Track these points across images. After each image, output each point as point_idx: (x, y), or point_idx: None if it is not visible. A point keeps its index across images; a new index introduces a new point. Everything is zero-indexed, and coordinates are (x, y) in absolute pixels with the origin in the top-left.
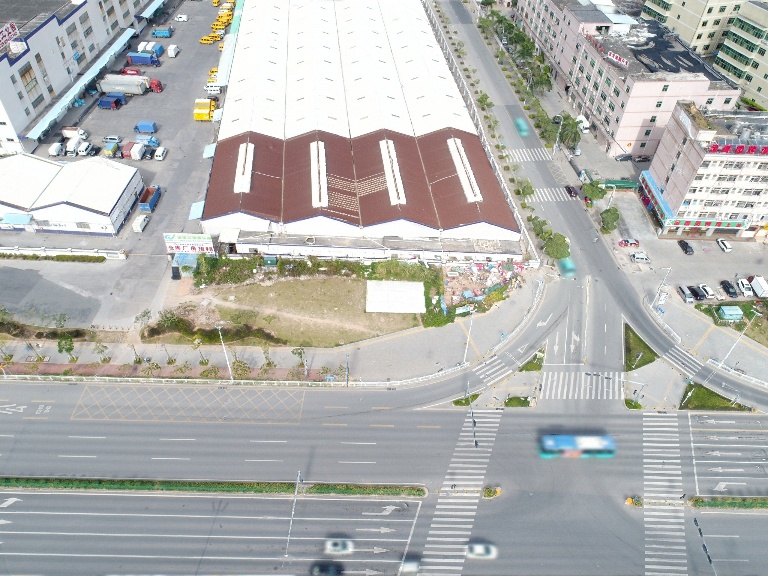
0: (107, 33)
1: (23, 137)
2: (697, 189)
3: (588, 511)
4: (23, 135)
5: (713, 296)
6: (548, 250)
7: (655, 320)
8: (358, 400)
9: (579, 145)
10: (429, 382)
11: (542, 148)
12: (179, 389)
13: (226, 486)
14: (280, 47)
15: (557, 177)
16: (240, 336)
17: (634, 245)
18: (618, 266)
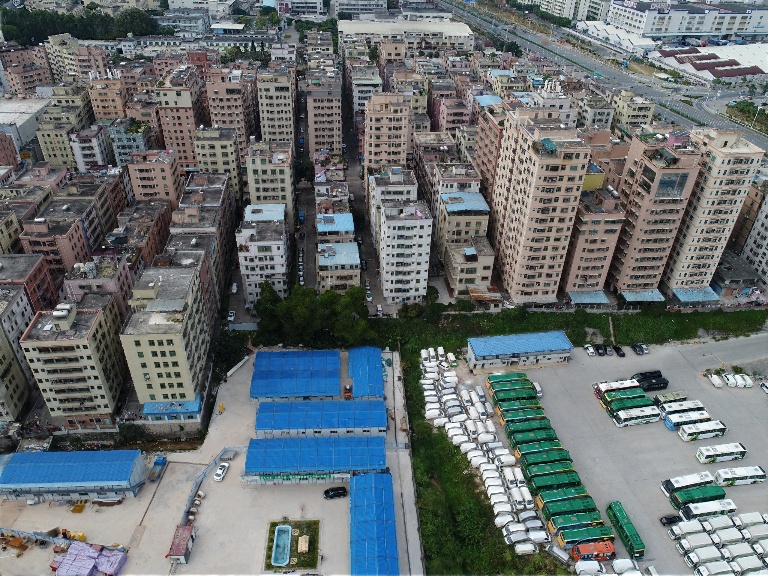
0: (711, 29)
1: (643, 34)
2: None
3: None
4: (644, 33)
5: None
6: None
7: None
8: None
9: None
10: None
11: None
12: None
13: None
14: (763, 48)
15: None
16: None
17: None
18: None
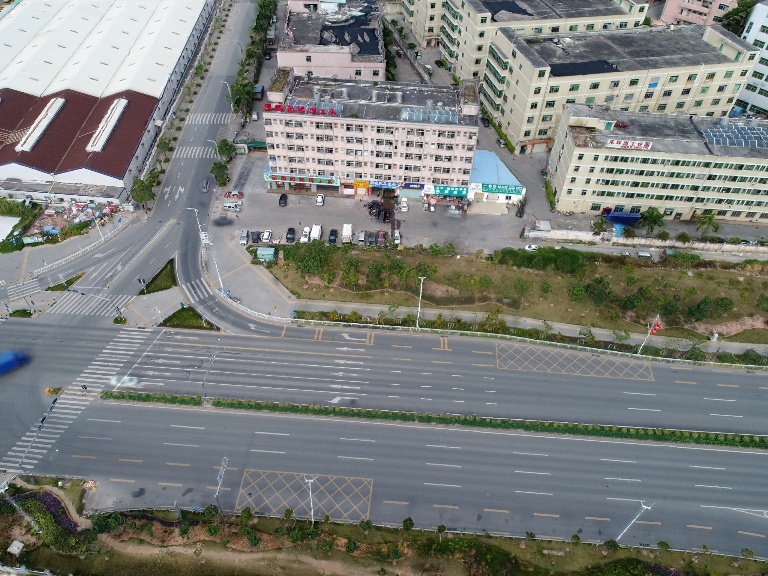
0: None
1: None
2: (274, 146)
3: (10, 396)
4: None
5: (267, 240)
6: (133, 194)
7: (201, 257)
8: None
9: None
10: None
11: (228, 113)
12: None
13: None
14: (44, 18)
15: (220, 138)
16: None
17: (237, 196)
18: (209, 213)
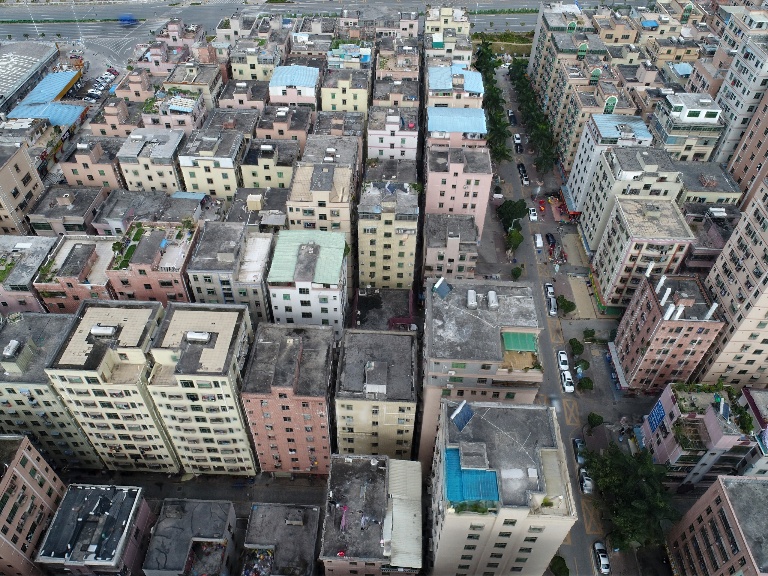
0: None
1: None
2: None
3: None
4: None
5: None
6: None
7: None
8: (128, 6)
9: None
10: (161, 2)
11: None
12: (51, 7)
13: (67, 20)
14: None
15: None
16: None
17: None
18: None
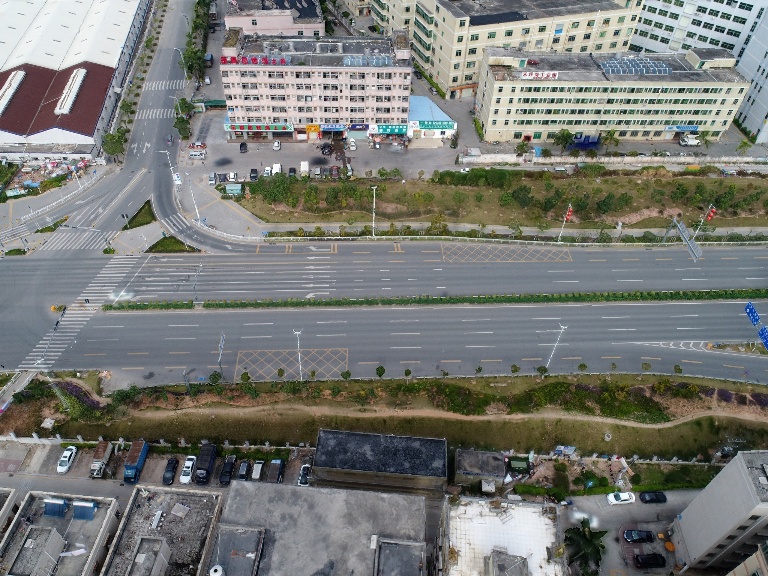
0: None
1: None
2: (232, 97)
3: (19, 316)
4: None
5: (233, 179)
6: (105, 148)
7: (175, 197)
8: None
9: (216, 77)
10: None
11: (182, 80)
12: None
13: None
14: None
15: None
16: None
17: (200, 147)
18: (177, 162)
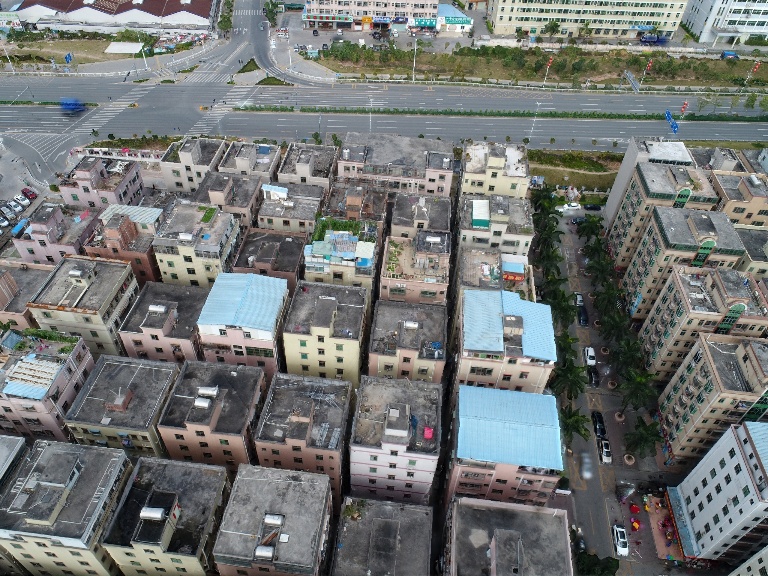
0: None
1: None
2: None
3: (179, 112)
4: None
5: None
6: (219, 25)
7: (271, 58)
8: (82, 81)
9: None
10: (125, 76)
11: None
12: None
13: None
14: None
15: (262, 5)
16: (25, 58)
17: (284, 31)
18: (268, 39)
